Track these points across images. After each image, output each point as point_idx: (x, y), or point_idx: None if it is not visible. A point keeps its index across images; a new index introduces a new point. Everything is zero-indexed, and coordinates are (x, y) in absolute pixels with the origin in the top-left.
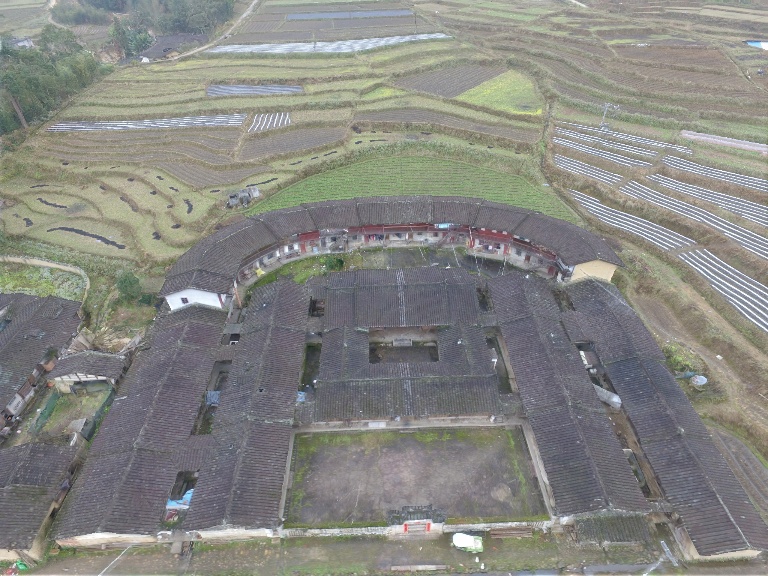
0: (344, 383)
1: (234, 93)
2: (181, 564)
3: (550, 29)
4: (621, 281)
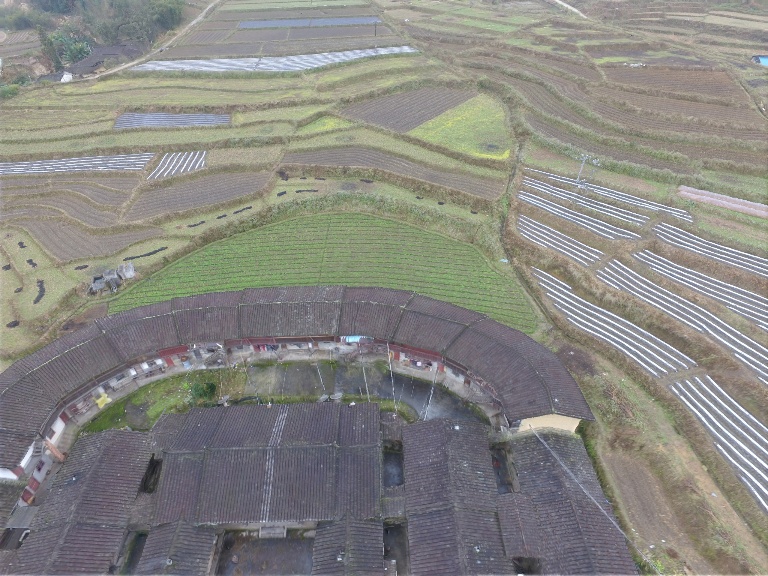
0: None
1: (147, 125)
2: None
3: (532, 42)
4: (591, 426)
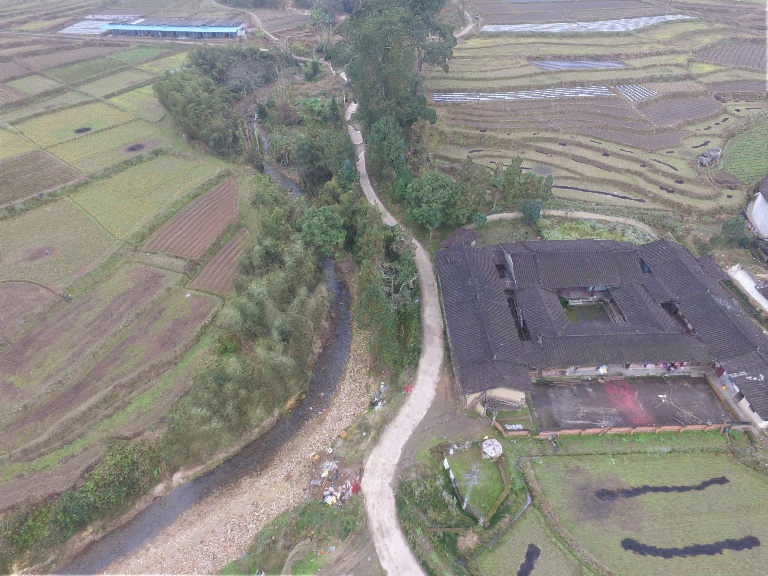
0: None
1: (567, 67)
2: None
3: None
4: None
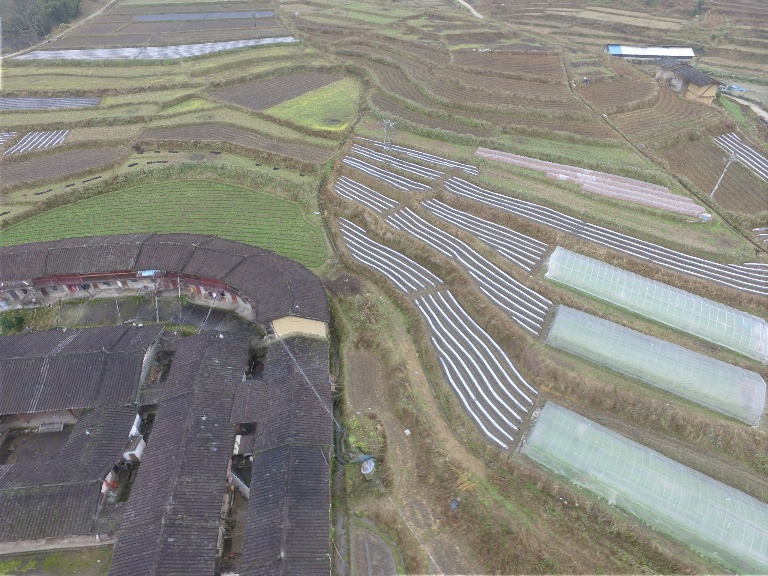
0: None
1: (15, 107)
2: None
3: (403, 33)
4: (343, 333)
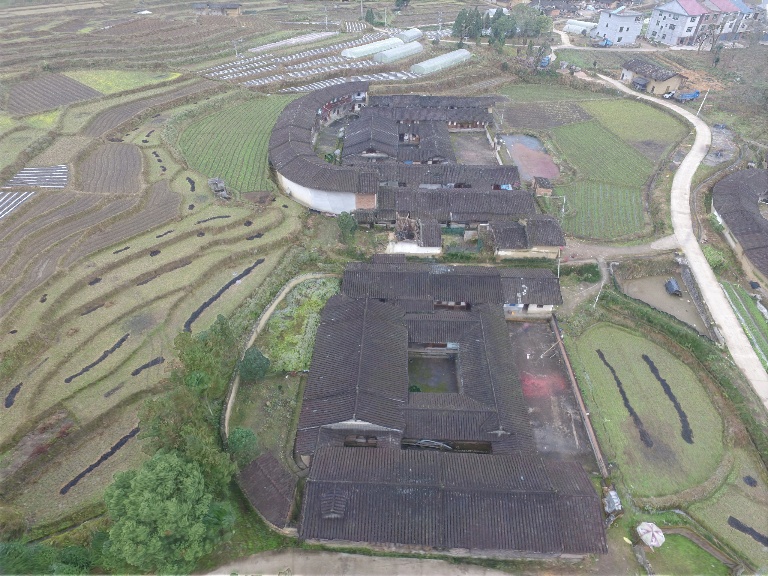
0: (438, 149)
1: None
2: None
3: (1, 40)
4: None
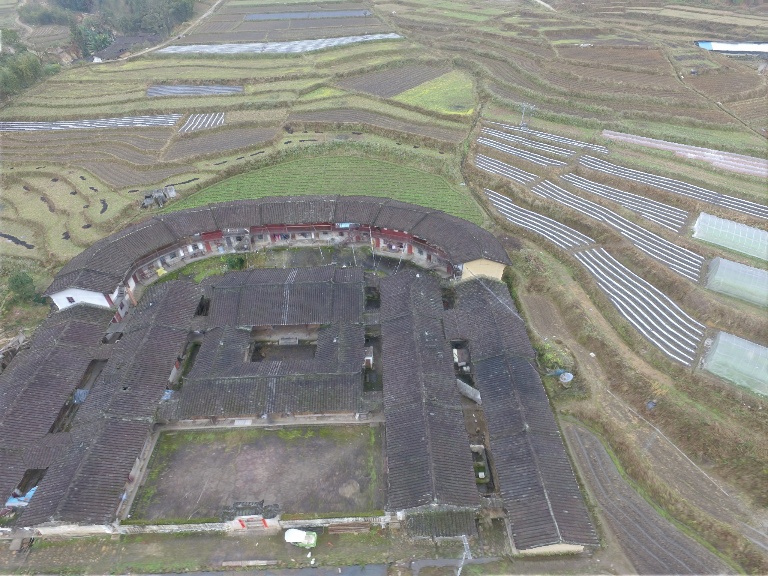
0: (210, 381)
1: (173, 93)
2: (17, 560)
3: (501, 29)
4: (515, 280)
